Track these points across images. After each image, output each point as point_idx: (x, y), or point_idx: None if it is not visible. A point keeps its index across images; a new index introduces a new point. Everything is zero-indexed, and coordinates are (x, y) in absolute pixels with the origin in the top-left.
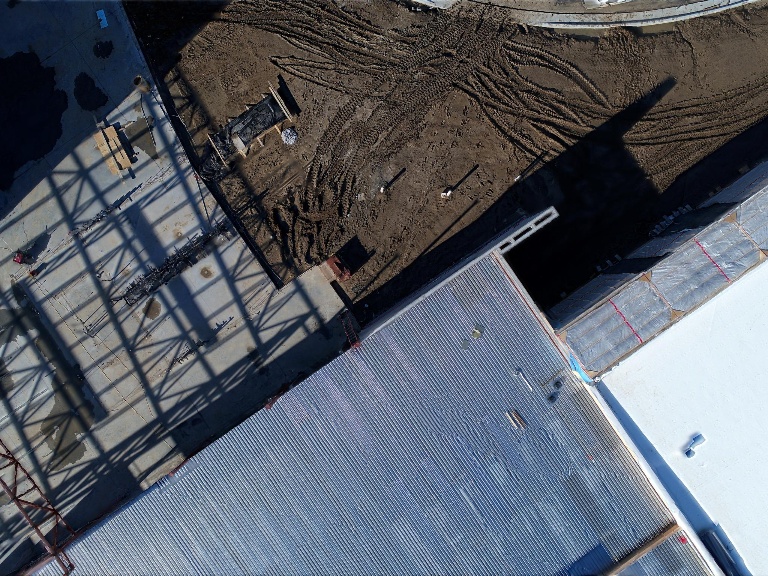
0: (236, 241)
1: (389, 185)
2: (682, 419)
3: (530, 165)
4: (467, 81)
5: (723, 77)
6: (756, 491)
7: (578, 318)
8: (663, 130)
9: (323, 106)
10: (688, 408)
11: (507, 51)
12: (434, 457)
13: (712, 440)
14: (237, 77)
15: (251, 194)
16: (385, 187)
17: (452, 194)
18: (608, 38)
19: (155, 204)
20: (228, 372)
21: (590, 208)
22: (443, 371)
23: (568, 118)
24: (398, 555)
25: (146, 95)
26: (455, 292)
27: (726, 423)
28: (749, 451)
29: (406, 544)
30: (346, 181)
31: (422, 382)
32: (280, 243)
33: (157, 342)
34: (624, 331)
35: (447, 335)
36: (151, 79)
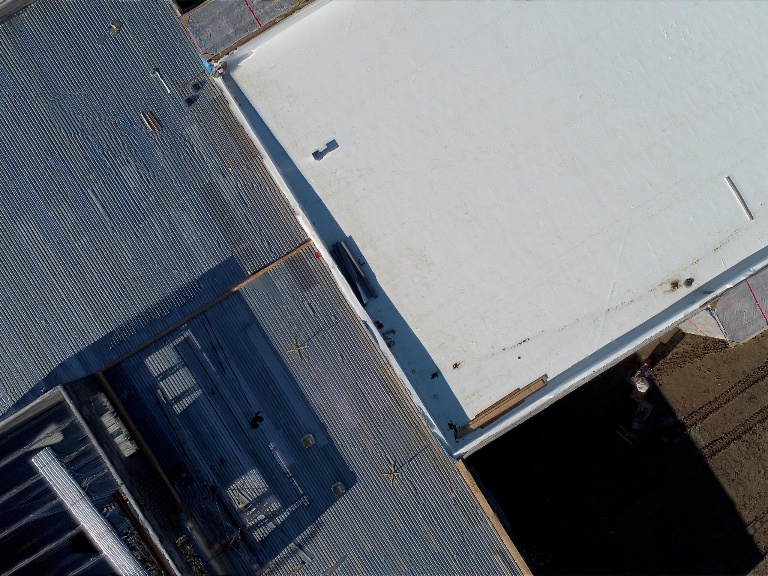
0: None
1: None
2: (315, 123)
3: None
4: None
5: None
6: (391, 204)
7: (202, 4)
8: None
9: None
10: (322, 111)
11: None
12: (62, 154)
13: (346, 147)
14: None
15: None
16: None
17: None
18: None
19: None
20: None
21: None
22: (76, 66)
23: None
24: (19, 253)
25: None
26: None
27: (361, 130)
28: (385, 161)
29: (28, 242)
30: None
31: (53, 76)
32: None
33: None
34: (245, 15)
35: (82, 29)
36: None
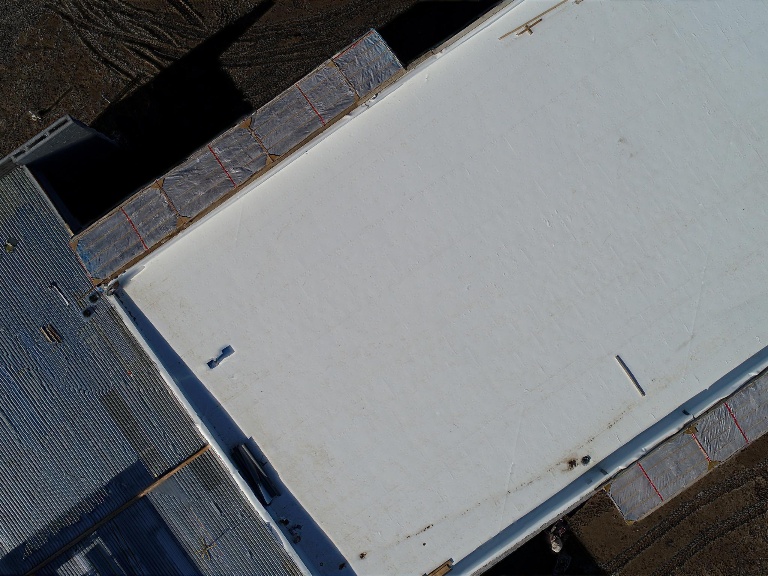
0: None
1: None
2: (210, 330)
3: (125, 87)
4: (61, 2)
5: None
6: (289, 403)
7: (91, 226)
8: (260, 51)
9: None
10: (216, 319)
11: None
12: None
13: (242, 352)
14: None
15: None
16: None
17: (45, 117)
18: None
19: None
20: None
21: (187, 131)
22: None
23: (163, 39)
24: None
25: None
26: None
27: (256, 334)
28: (280, 363)
29: None
30: None
31: None
32: None
33: None
34: (131, 238)
35: None
36: None
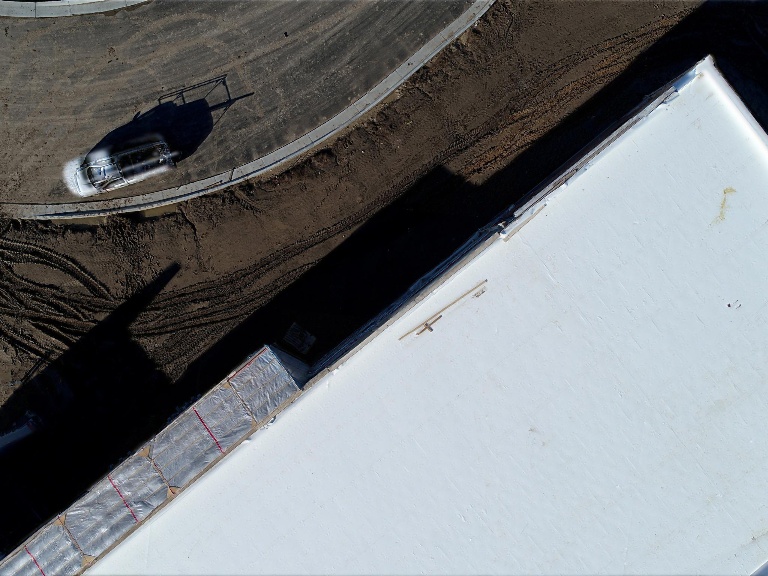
0: None
1: None
2: None
3: (34, 366)
4: None
5: (228, 258)
6: None
7: None
8: (169, 318)
9: None
10: None
11: None
12: None
13: None
14: None
15: None
16: None
17: None
18: (106, 227)
19: None
20: None
21: (102, 404)
22: None
23: (69, 314)
24: None
25: None
26: None
27: None
28: None
29: None
30: None
31: None
32: None
33: None
34: None
35: None
36: None
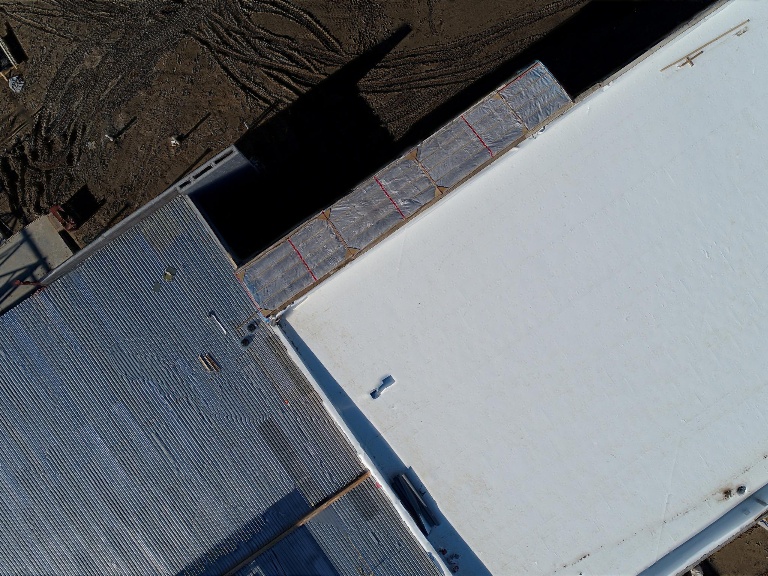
0: None
1: (120, 133)
2: (371, 360)
3: (263, 113)
4: (199, 28)
5: (459, 24)
6: (448, 433)
7: (257, 257)
8: (398, 77)
9: (51, 53)
10: (377, 349)
11: None
12: (125, 401)
13: (402, 382)
14: None
15: None
16: (115, 135)
17: (184, 142)
18: None
19: None
20: None
21: (324, 156)
22: (134, 314)
23: (301, 65)
24: (88, 500)
25: None
26: (146, 234)
27: (416, 364)
28: (440, 393)
29: (96, 489)
30: (76, 130)
31: (113, 325)
32: (8, 192)
33: None
34: (299, 269)
35: (138, 277)
36: None
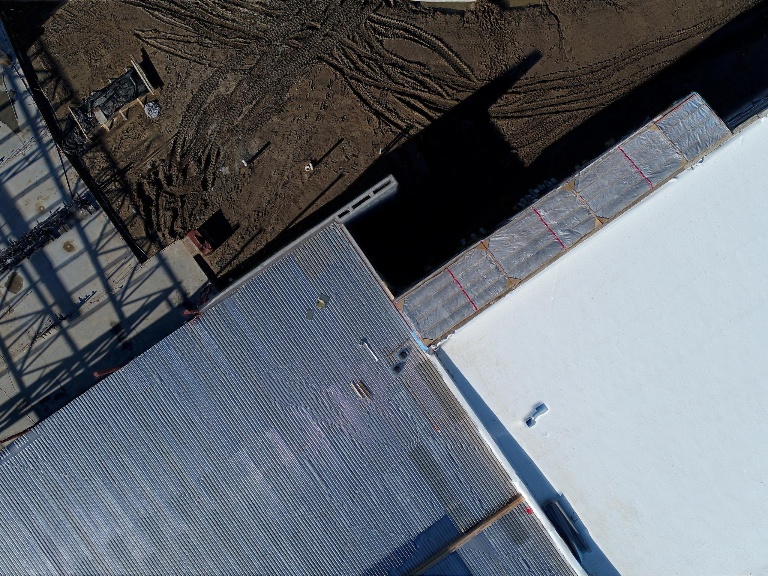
0: (99, 215)
1: (253, 159)
2: (525, 388)
3: (395, 138)
4: (332, 54)
5: (589, 50)
6: (600, 461)
7: (416, 286)
8: (529, 103)
9: (186, 79)
10: (530, 377)
11: (372, 24)
12: (278, 428)
13: (555, 410)
14: (100, 50)
15: (115, 168)
16: (249, 161)
17: (317, 168)
18: (474, 11)
19: (17, 178)
20: (91, 346)
21: (456, 182)
22: (287, 341)
23: (433, 91)
24: (242, 526)
25: (8, 68)
26: (299, 262)
27: (569, 392)
28: (593, 421)
29: (250, 515)
30: (210, 155)
31: (266, 352)
32: (143, 217)
33: (19, 316)
34: (460, 299)
35: (291, 305)
36: (13, 52)
